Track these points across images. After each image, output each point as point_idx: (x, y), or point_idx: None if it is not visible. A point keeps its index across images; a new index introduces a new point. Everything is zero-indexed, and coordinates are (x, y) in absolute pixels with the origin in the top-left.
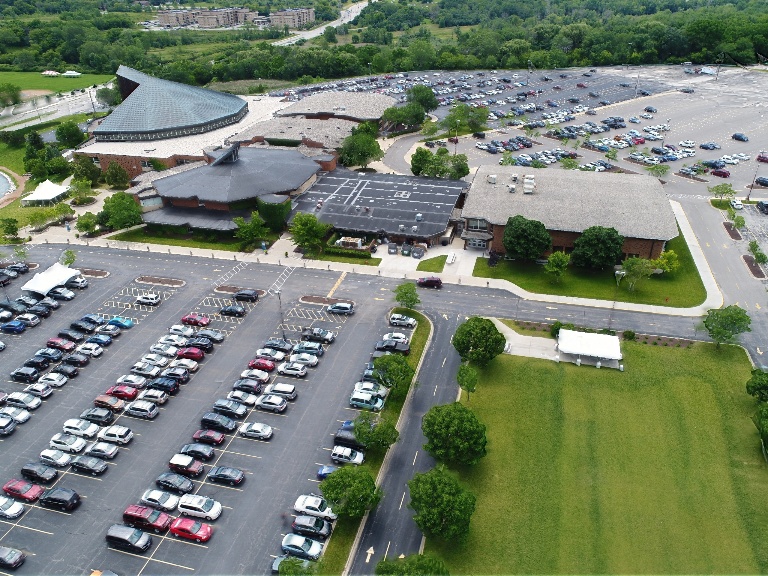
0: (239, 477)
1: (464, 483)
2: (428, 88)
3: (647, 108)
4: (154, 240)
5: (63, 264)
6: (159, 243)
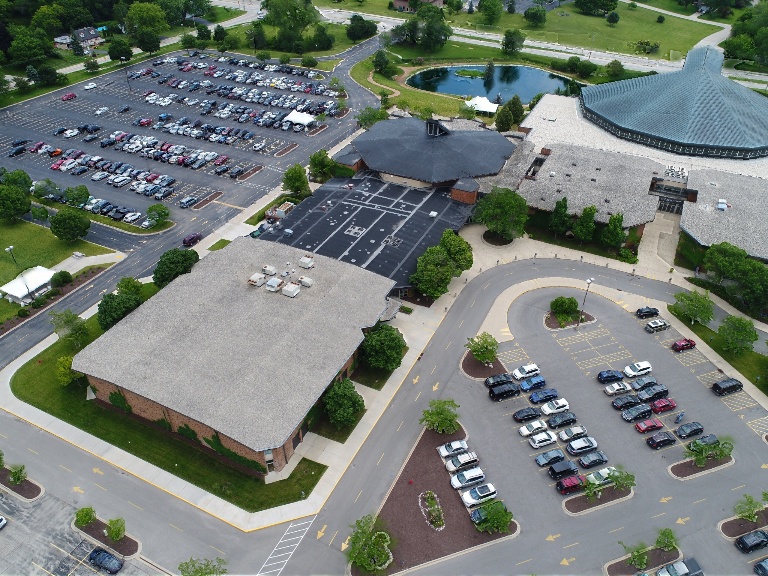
0: (73, 171)
1: (0, 221)
2: None
3: None
4: None
5: (314, 117)
6: None
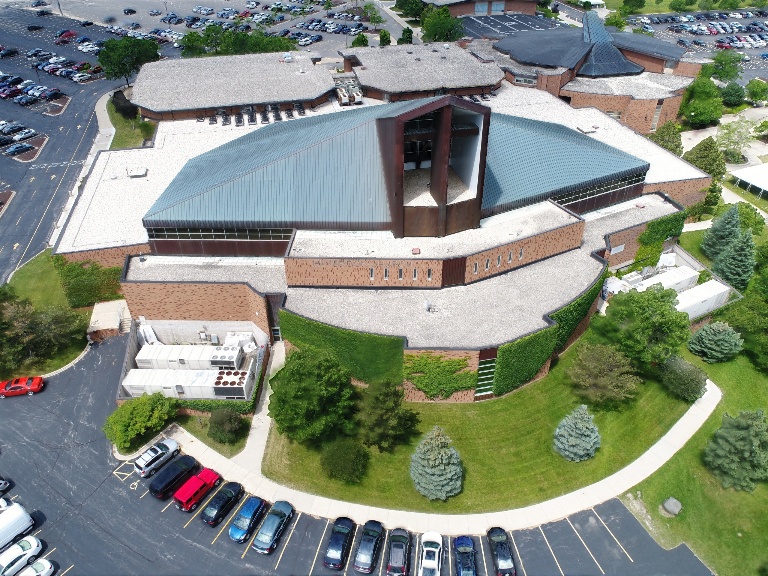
0: (754, 21)
1: None
2: None
3: (130, 11)
4: None
5: None
6: None
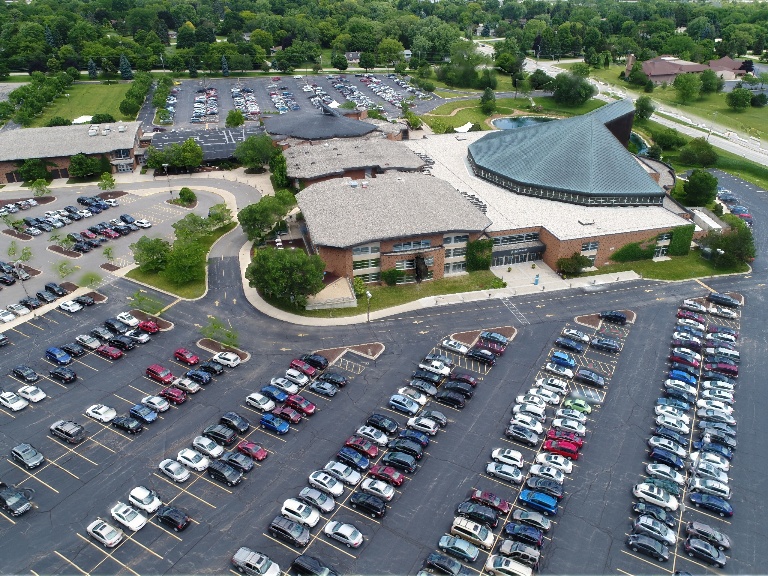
0: None
1: None
2: (273, 258)
3: None
4: None
5: None
6: None
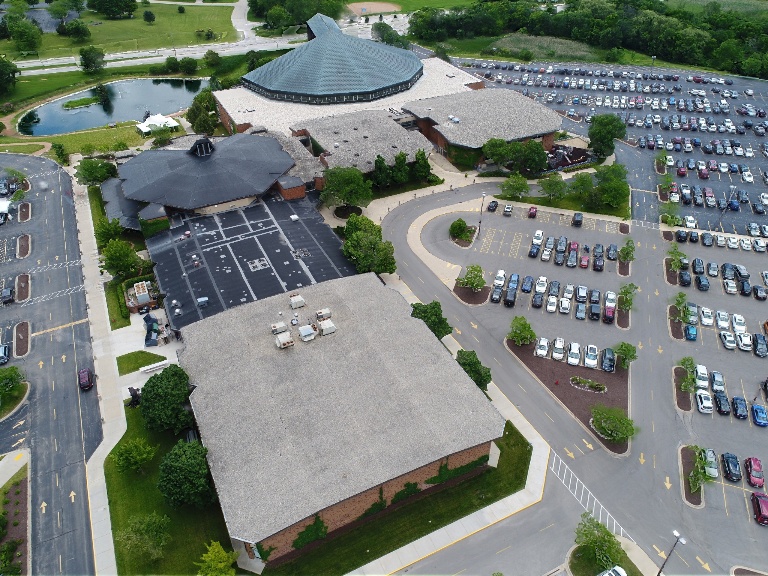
0: None
1: None
2: (616, 123)
3: None
4: (95, 205)
5: (8, 199)
6: (92, 209)
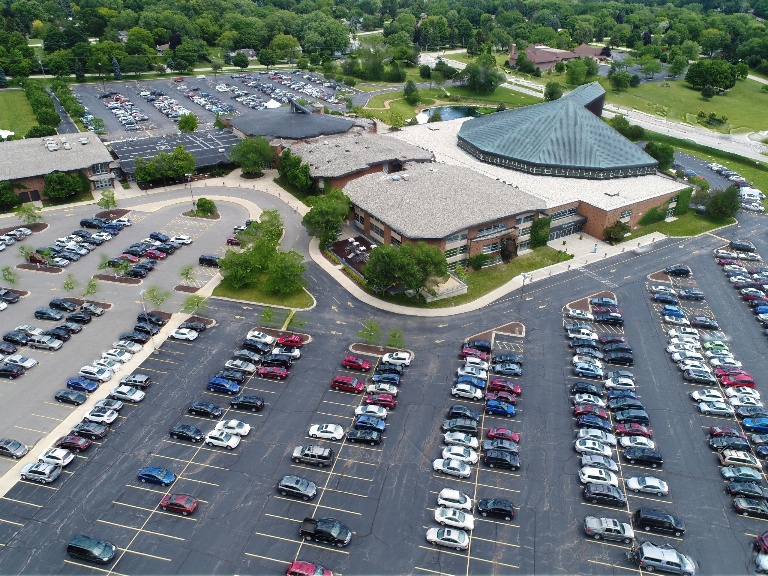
0: None
1: None
2: (401, 255)
3: None
4: None
5: None
6: None
